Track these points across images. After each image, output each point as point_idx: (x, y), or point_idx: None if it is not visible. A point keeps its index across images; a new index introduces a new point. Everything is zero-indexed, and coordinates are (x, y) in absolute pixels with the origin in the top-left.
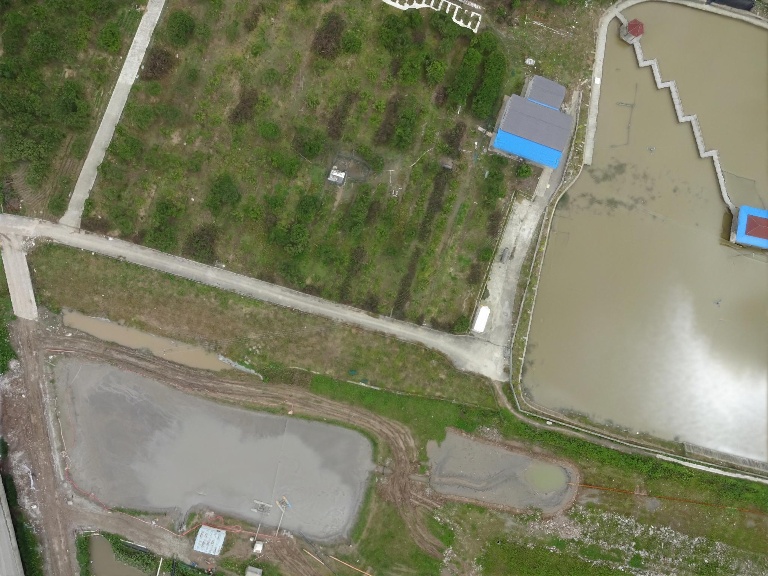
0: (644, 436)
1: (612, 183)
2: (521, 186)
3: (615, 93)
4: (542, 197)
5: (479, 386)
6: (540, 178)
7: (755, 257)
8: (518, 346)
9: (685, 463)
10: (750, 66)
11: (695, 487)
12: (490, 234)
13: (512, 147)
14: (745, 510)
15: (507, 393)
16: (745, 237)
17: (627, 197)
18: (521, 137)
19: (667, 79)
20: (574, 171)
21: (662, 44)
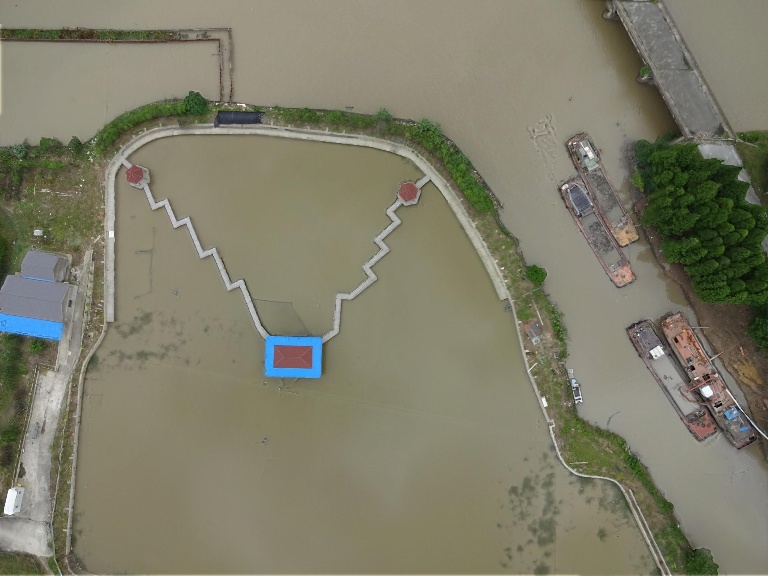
0: None
1: (140, 335)
2: (43, 359)
3: (134, 241)
4: (65, 365)
5: (25, 564)
6: (59, 348)
7: None
8: (61, 518)
9: None
10: (276, 179)
11: None
12: (15, 413)
13: (21, 325)
14: None
15: (53, 568)
16: (274, 370)
17: (157, 347)
18: (21, 316)
19: (185, 215)
20: (96, 332)
21: (177, 180)
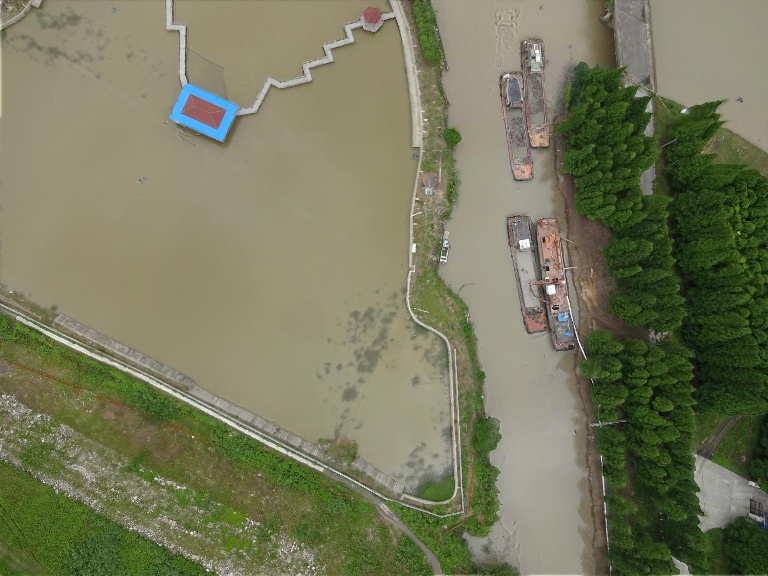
0: (16, 296)
1: (60, 33)
2: None
3: None
4: None
5: None
6: None
7: (182, 137)
8: None
9: (47, 333)
10: None
11: (55, 361)
12: None
13: None
14: (105, 399)
15: None
16: (180, 116)
17: (72, 50)
18: None
19: None
20: (15, 9)
21: None
